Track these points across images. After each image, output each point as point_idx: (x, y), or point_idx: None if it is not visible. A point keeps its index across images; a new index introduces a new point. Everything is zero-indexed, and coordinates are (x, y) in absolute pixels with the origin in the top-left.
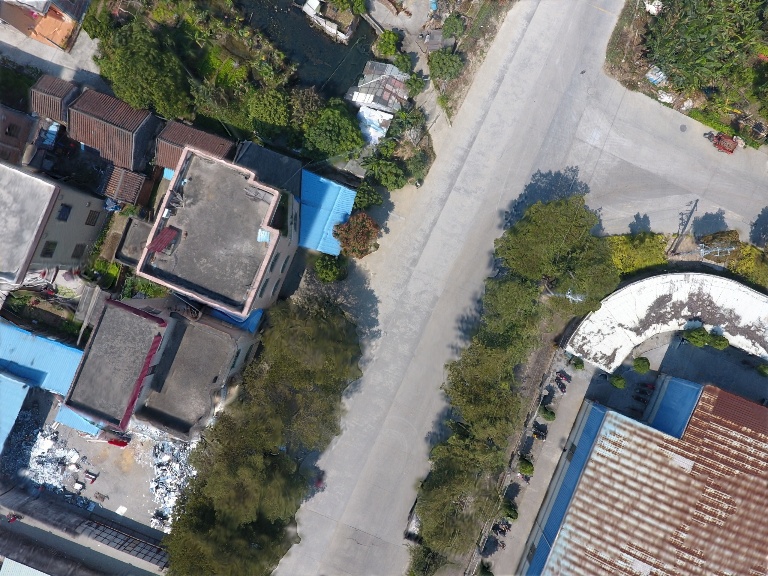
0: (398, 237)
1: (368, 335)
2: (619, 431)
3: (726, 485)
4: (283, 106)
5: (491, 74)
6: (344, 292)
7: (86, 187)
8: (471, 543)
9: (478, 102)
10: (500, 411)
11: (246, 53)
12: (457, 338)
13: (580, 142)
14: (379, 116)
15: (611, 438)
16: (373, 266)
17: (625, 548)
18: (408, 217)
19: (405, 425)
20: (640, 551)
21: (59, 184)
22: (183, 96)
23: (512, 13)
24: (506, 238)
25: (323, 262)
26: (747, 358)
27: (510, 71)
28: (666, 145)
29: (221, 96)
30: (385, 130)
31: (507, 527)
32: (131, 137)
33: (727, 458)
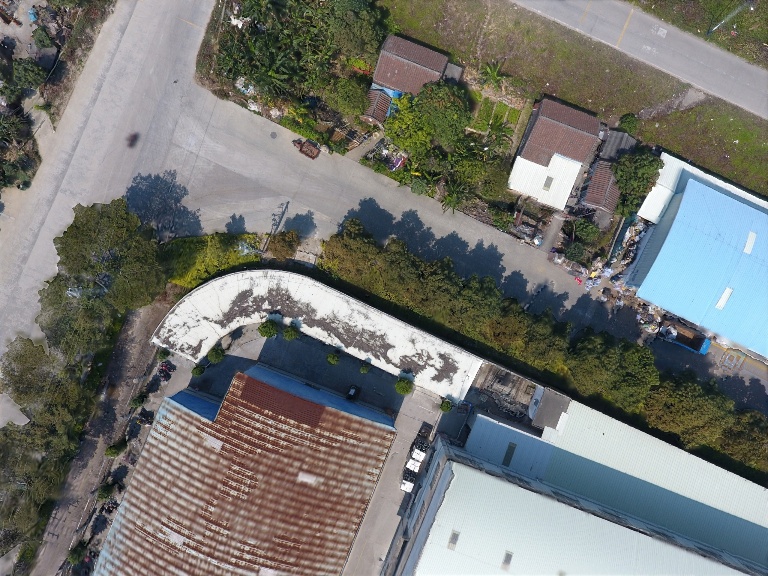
0: (8, 236)
1: None
2: (169, 415)
3: (249, 463)
4: None
5: (90, 82)
6: None
7: None
8: (27, 520)
9: (79, 109)
10: (58, 398)
11: None
12: None
13: (177, 147)
14: None
15: (163, 422)
16: None
17: (165, 522)
18: (17, 217)
19: (18, 413)
20: (176, 524)
21: None
22: None
23: (107, 25)
24: None
25: None
26: (335, 348)
27: (108, 80)
28: (258, 151)
29: None
30: None
31: (114, 506)
32: None
33: (250, 438)
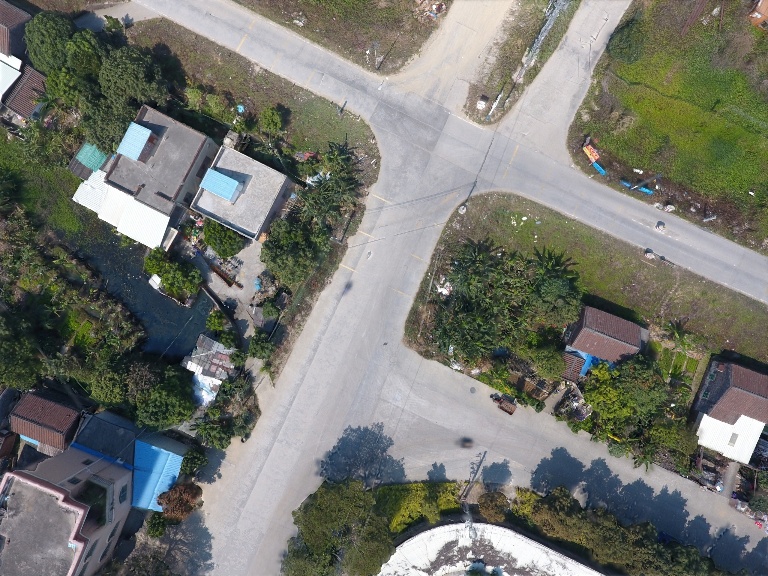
0: (229, 482)
1: (203, 567)
2: None
3: None
4: (119, 387)
5: (308, 344)
6: (182, 529)
7: None
8: None
9: (297, 367)
10: None
11: None
12: None
13: (384, 402)
14: (210, 381)
15: None
16: (207, 507)
17: None
18: (238, 465)
19: None
20: None
21: None
22: (38, 369)
23: (324, 293)
24: (301, 511)
25: (152, 521)
26: None
27: (323, 342)
28: (458, 405)
29: (73, 364)
30: (215, 394)
31: None
32: None
33: None
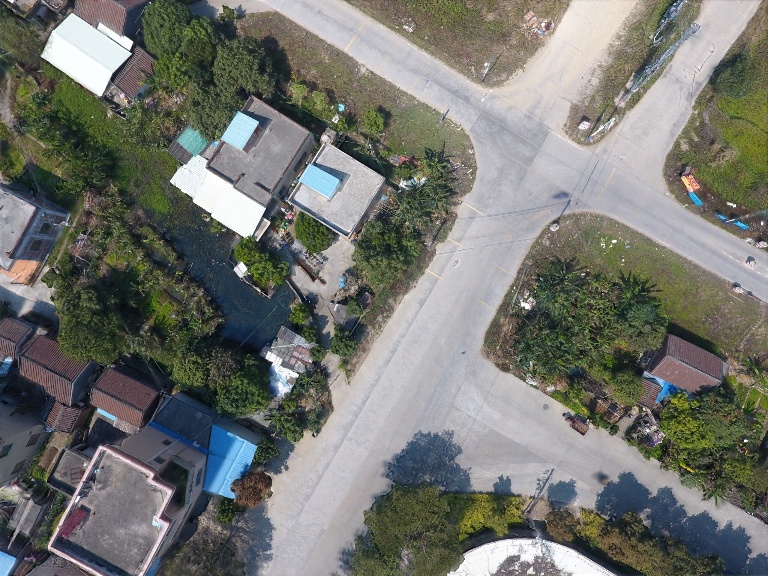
0: (295, 475)
1: (261, 557)
2: None
3: None
4: (201, 371)
5: (386, 346)
6: (244, 517)
7: (30, 417)
8: None
9: (373, 368)
10: None
11: (183, 297)
12: (338, 567)
13: (457, 410)
14: (287, 373)
15: None
16: (272, 497)
17: None
18: (305, 458)
19: None
20: None
21: (4, 422)
22: (121, 345)
23: (408, 297)
24: (373, 511)
25: (222, 506)
26: None
27: (402, 345)
28: (530, 420)
29: (154, 344)
30: (291, 386)
31: None
32: (70, 385)
33: None
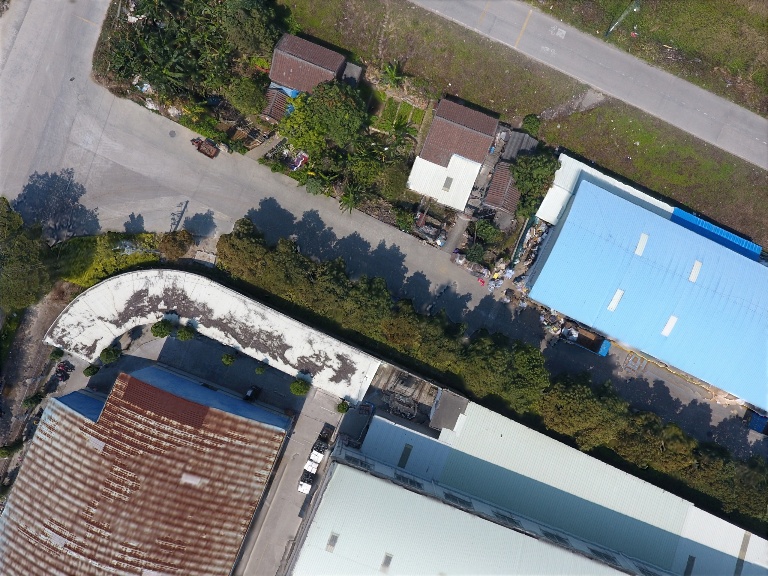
0: None
1: None
2: (54, 416)
3: (131, 464)
4: None
5: None
6: None
7: None
8: None
9: None
10: None
11: None
12: None
13: (74, 146)
14: None
15: (48, 423)
16: None
17: (47, 523)
18: None
19: None
20: (58, 526)
21: None
22: None
23: (2, 21)
24: None
25: None
26: None
27: (3, 77)
28: (156, 149)
29: None
30: None
31: None
32: None
33: (132, 439)
